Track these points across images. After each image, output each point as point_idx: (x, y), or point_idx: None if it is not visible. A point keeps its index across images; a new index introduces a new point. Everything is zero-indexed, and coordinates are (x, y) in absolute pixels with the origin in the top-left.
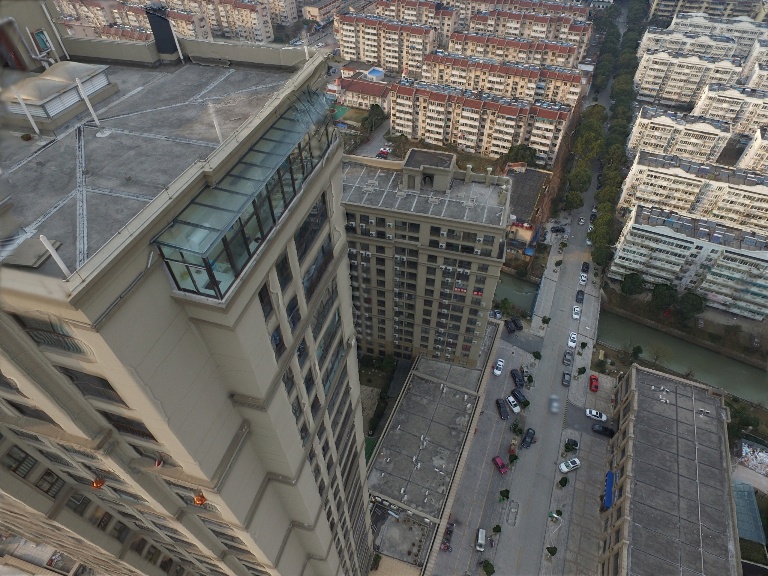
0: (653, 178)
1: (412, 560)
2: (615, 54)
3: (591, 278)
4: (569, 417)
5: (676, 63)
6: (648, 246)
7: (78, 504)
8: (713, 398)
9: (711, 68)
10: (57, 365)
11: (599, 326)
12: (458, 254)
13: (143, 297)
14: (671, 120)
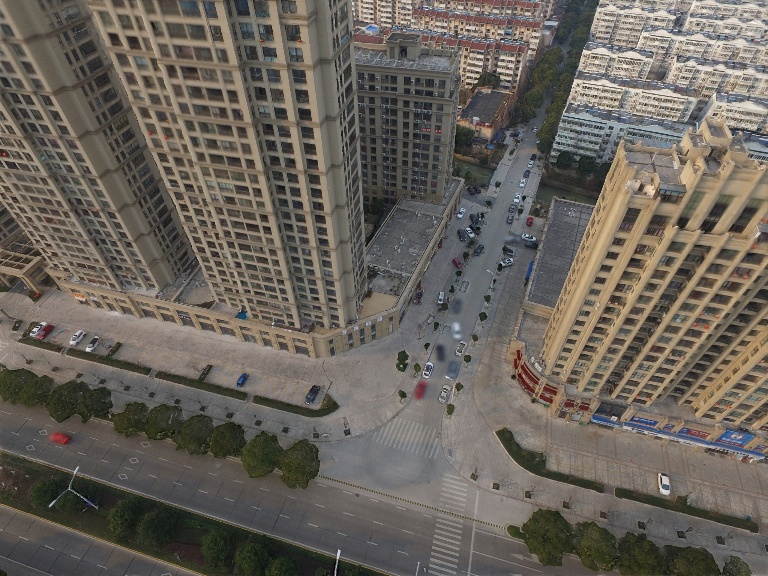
0: (587, 89)
1: (393, 293)
2: (578, 13)
3: (537, 163)
4: (509, 240)
5: (623, 14)
6: (575, 130)
7: (244, 76)
8: None
9: (651, 17)
10: None
11: (538, 190)
12: (423, 97)
13: None
14: (607, 50)
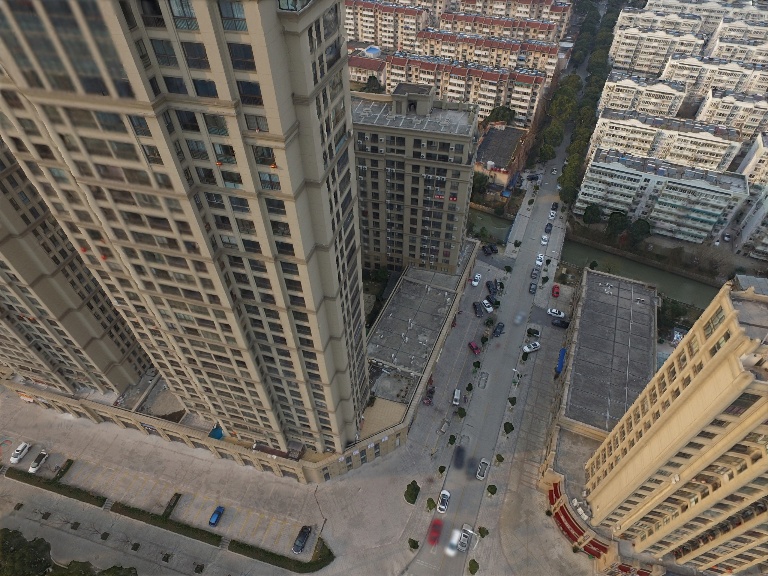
0: (614, 129)
1: (400, 400)
2: (593, 33)
3: (559, 214)
4: (533, 315)
5: (645, 37)
6: (605, 181)
7: (198, 203)
8: (649, 291)
9: (676, 41)
10: (228, 43)
11: (563, 249)
12: (436, 162)
13: (269, 3)
14: (634, 82)
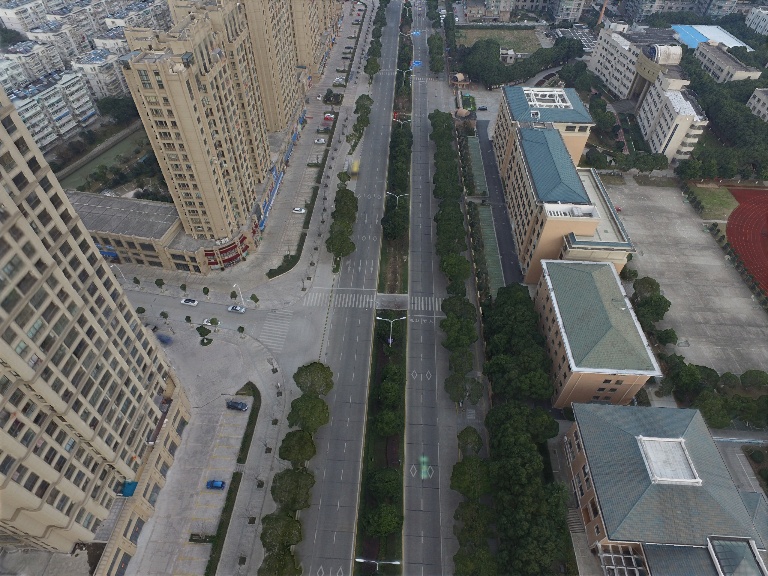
0: None
1: None
2: None
3: None
4: None
5: None
6: None
7: None
8: None
9: None
10: None
11: None
12: None
13: None
14: None
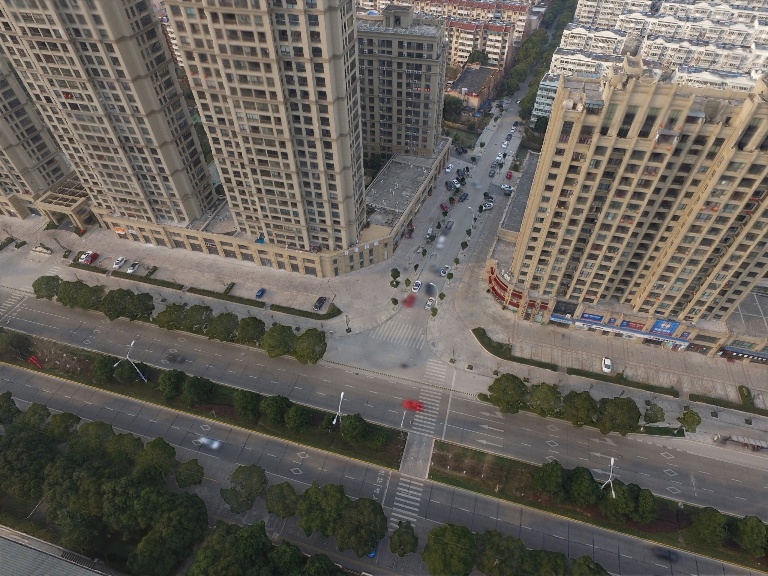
0: (564, 63)
1: (388, 225)
2: (564, 0)
3: (519, 129)
4: (491, 190)
5: None
6: (551, 97)
7: None
8: None
9: (629, 2)
10: None
11: (518, 150)
12: (414, 59)
13: None
14: (585, 30)
